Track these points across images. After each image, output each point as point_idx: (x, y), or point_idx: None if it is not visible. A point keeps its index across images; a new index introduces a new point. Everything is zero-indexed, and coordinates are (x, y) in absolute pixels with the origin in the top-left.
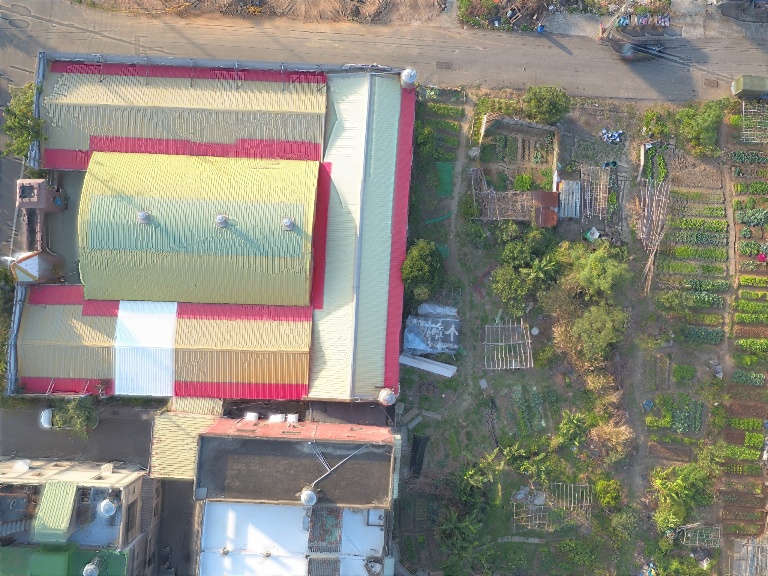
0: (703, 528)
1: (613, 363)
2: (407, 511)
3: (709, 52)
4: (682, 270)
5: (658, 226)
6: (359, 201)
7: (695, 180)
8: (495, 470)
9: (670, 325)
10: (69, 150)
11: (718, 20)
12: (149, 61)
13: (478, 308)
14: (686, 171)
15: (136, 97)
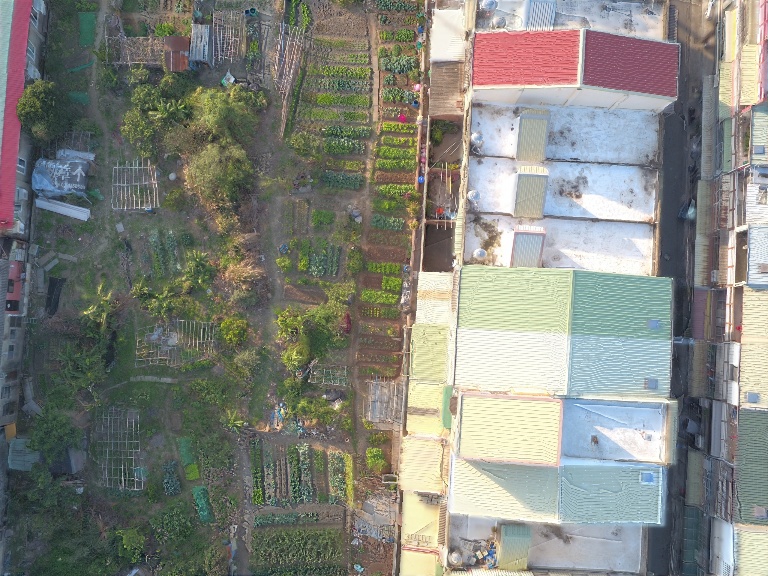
0: (329, 367)
1: (248, 207)
2: (41, 351)
3: None
4: (324, 116)
5: (291, 69)
6: None
7: (340, 28)
8: (101, 300)
9: (309, 170)
10: None
11: None
12: None
13: (117, 154)
14: (331, 19)
15: None
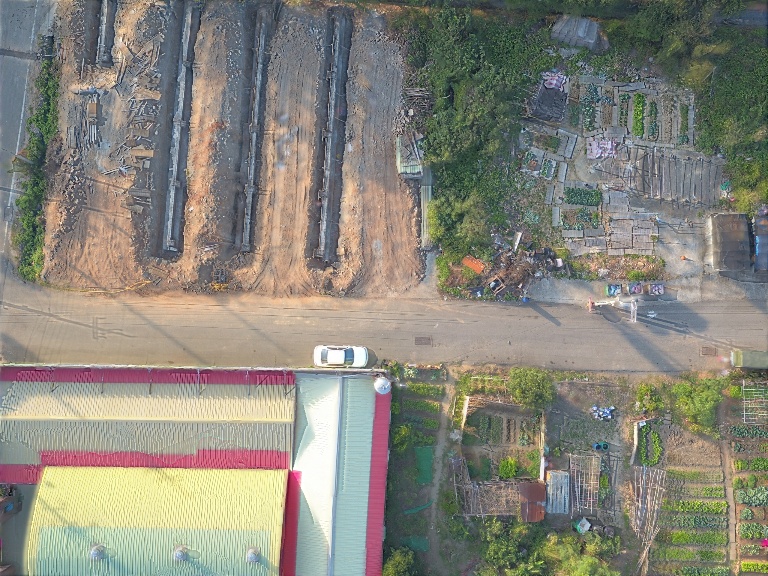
0: None
1: None
2: None
3: (706, 317)
4: (679, 557)
5: (653, 518)
6: (331, 518)
7: (692, 458)
8: None
9: None
10: (20, 465)
11: (716, 281)
12: (108, 345)
13: None
14: (683, 448)
15: (91, 409)
